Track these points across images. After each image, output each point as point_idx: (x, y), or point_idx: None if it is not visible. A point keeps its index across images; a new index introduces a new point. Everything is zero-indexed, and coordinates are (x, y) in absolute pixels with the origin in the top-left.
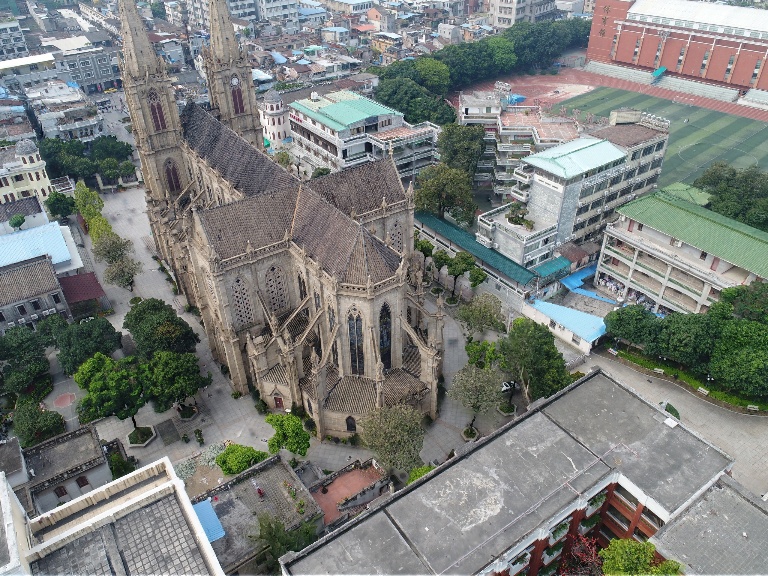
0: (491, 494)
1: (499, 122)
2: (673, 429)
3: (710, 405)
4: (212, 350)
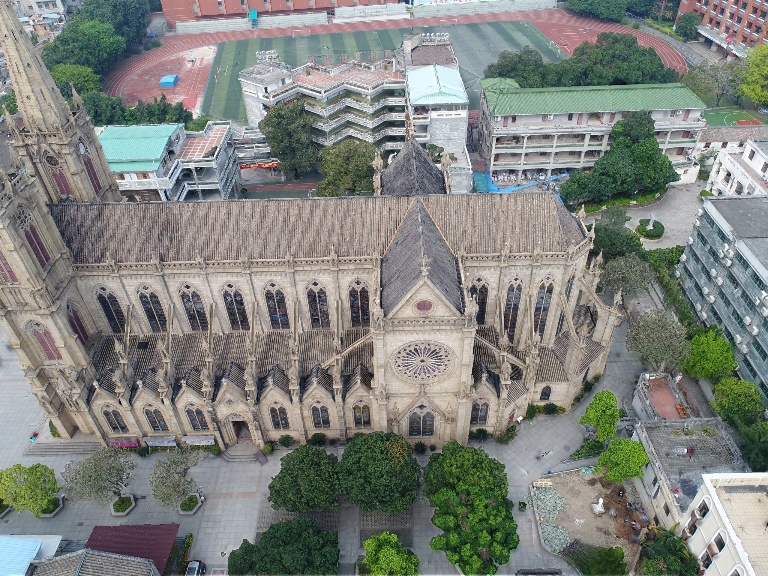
0: None
1: (314, 87)
2: None
3: (644, 208)
4: None
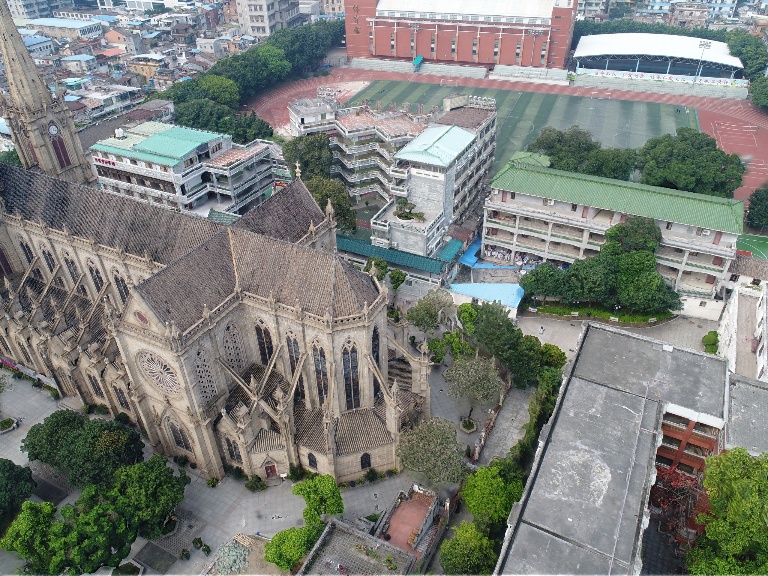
0: (594, 464)
1: (342, 126)
2: (673, 352)
3: None
4: (155, 445)
